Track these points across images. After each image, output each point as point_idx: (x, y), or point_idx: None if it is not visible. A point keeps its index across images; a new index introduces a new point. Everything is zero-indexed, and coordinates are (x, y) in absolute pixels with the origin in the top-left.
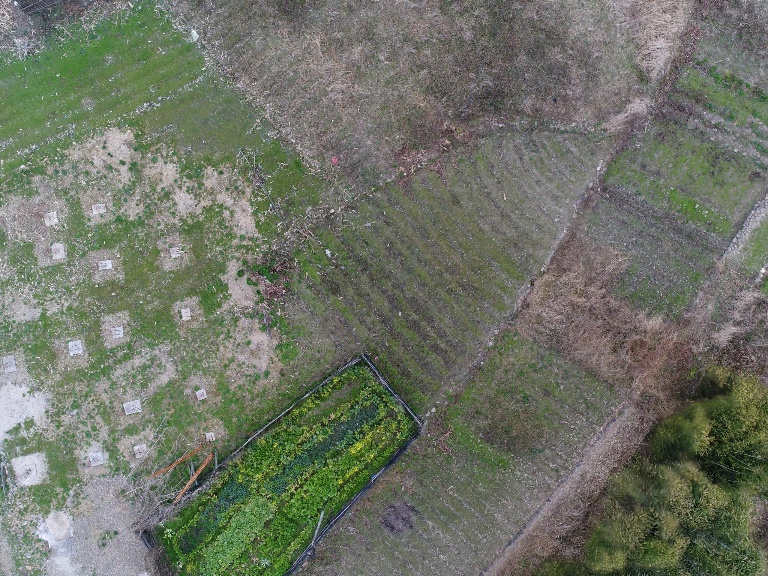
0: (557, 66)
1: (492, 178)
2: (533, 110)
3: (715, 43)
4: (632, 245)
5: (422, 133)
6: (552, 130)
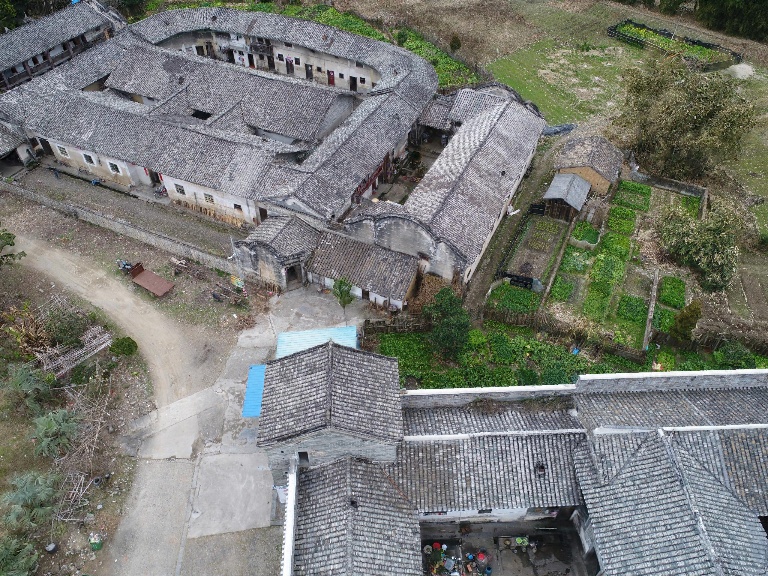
0: None
1: None
2: (505, 8)
3: None
4: (544, 1)
5: None
6: (511, 6)
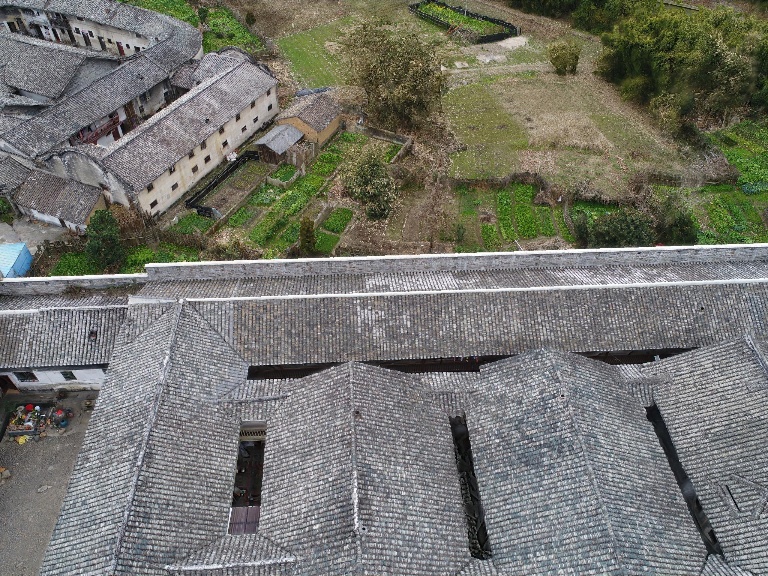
0: None
1: None
2: None
3: None
4: None
5: (332, 3)
6: None
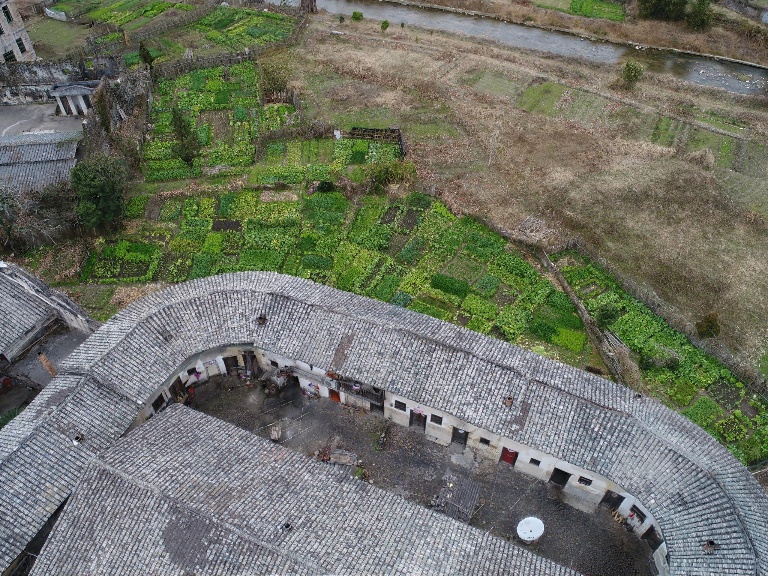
0: (685, 183)
1: (763, 206)
2: None
3: (638, 140)
4: (759, 165)
5: None
6: None
